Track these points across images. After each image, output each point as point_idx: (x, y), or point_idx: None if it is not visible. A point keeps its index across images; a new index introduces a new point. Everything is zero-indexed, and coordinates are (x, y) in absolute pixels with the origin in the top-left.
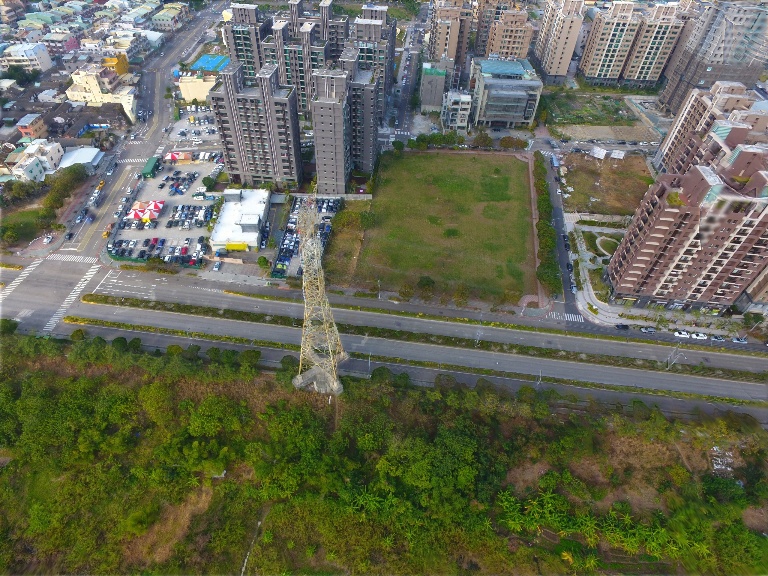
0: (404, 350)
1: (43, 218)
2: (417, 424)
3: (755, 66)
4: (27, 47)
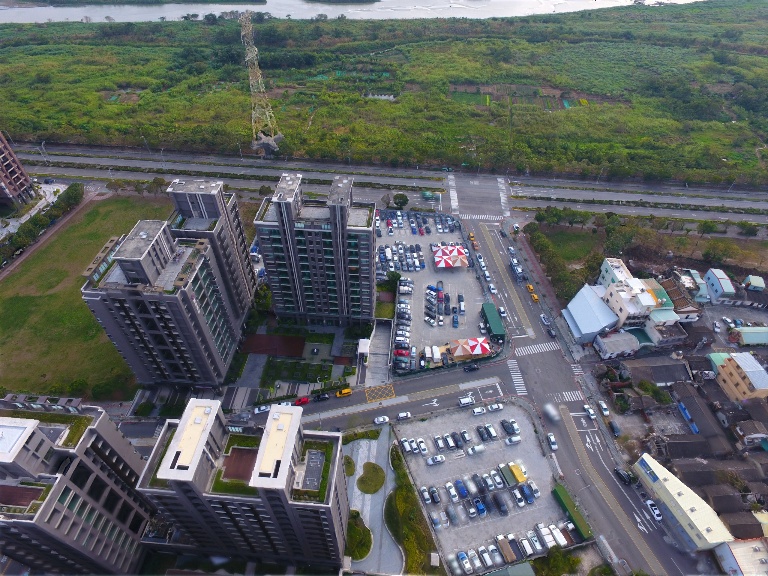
0: (216, 169)
1: (529, 225)
2: (222, 135)
3: None
4: None
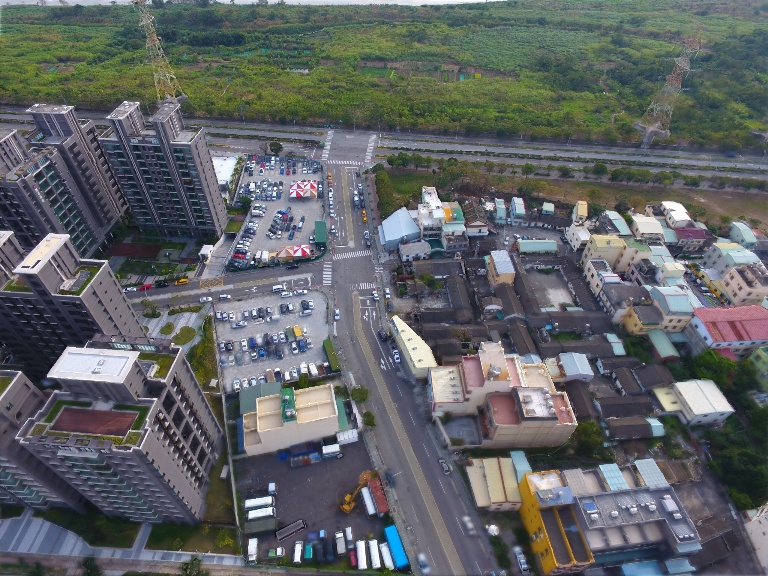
0: None
1: (376, 165)
2: None
3: None
4: None
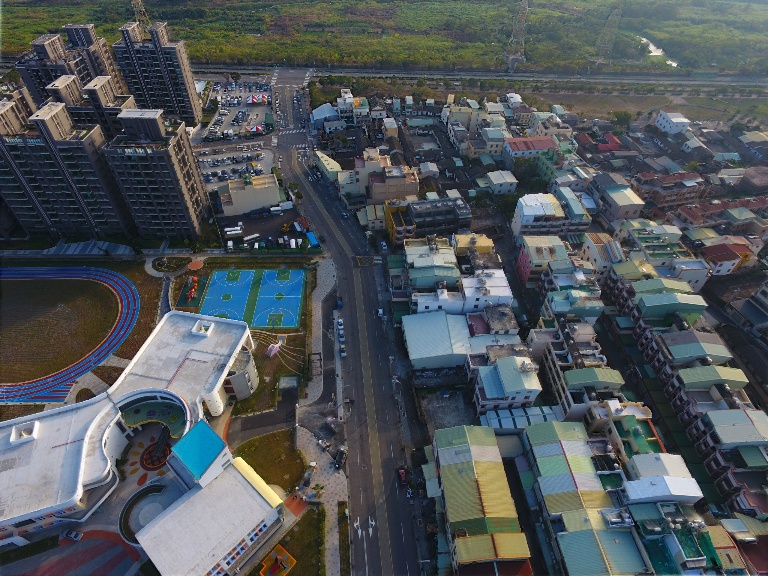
0: None
1: None
2: None
3: None
4: (529, 200)
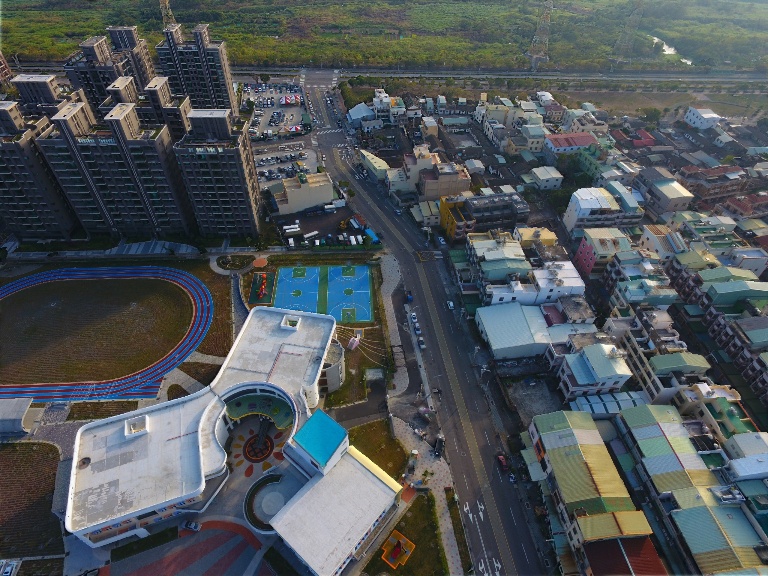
0: None
1: (340, 83)
2: None
3: None
4: (584, 194)
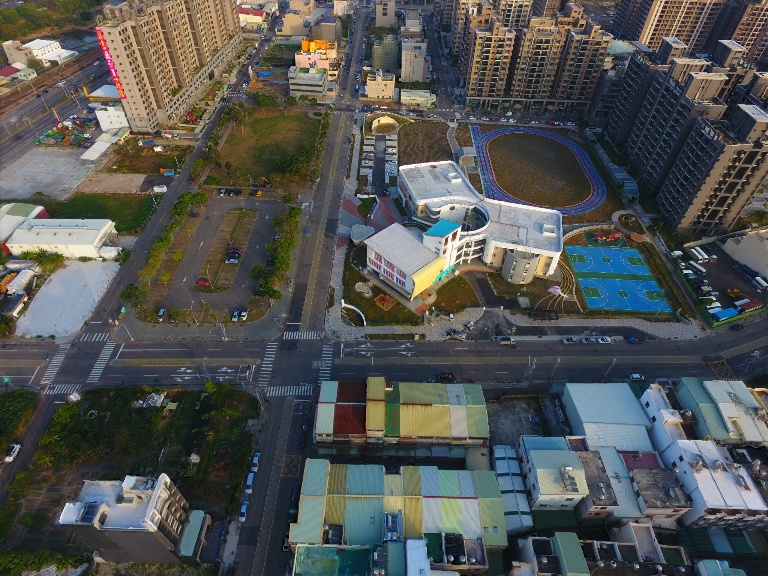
0: None
1: None
2: None
3: (427, 3)
4: None
